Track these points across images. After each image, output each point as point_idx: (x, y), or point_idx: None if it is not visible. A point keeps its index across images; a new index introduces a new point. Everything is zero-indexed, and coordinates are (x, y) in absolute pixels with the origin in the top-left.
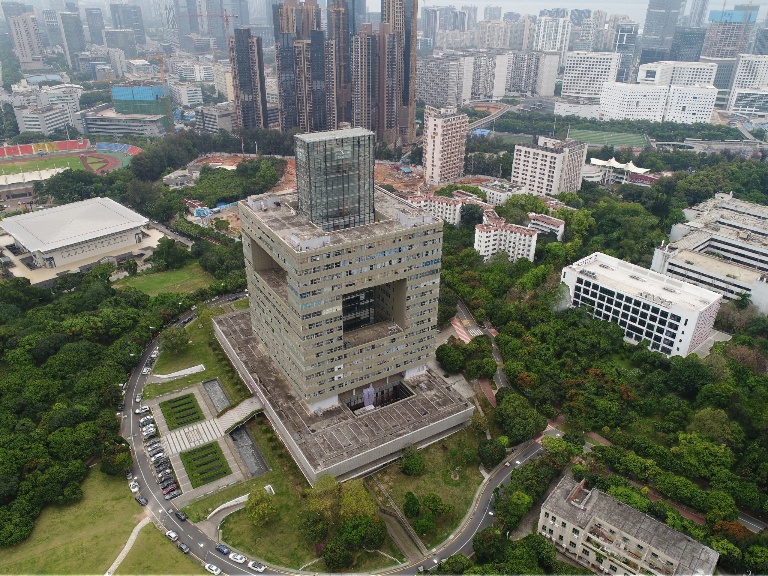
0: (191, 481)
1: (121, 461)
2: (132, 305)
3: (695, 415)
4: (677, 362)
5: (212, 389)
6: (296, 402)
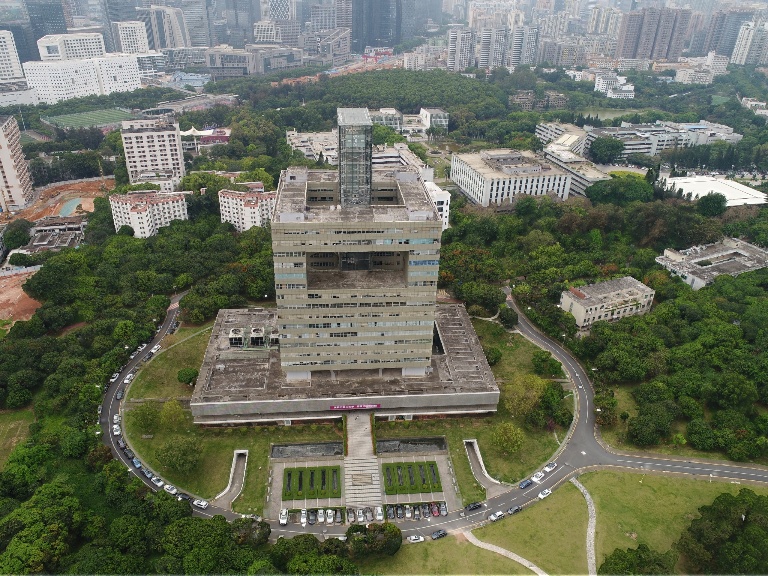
0: (431, 492)
1: (397, 528)
2: (5, 496)
3: (530, 239)
4: (472, 225)
5: (288, 453)
6: (404, 379)
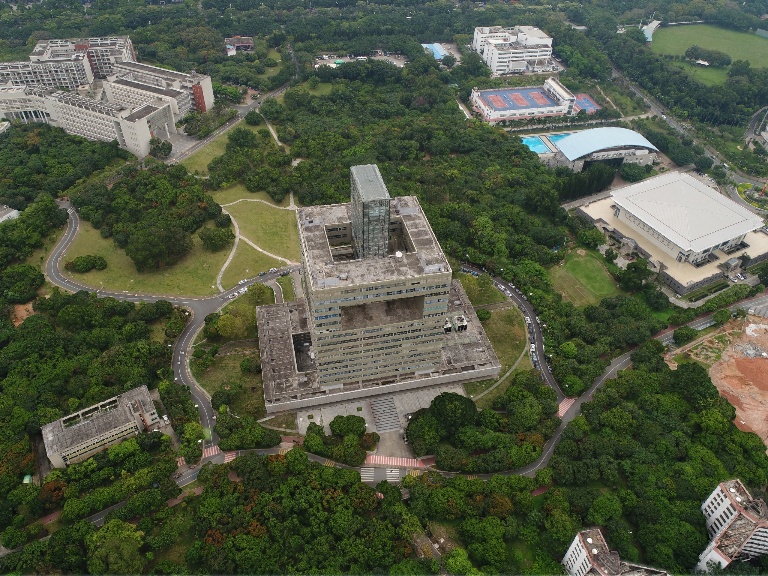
0: None
1: None
2: None
3: None
4: None
5: None
6: None
